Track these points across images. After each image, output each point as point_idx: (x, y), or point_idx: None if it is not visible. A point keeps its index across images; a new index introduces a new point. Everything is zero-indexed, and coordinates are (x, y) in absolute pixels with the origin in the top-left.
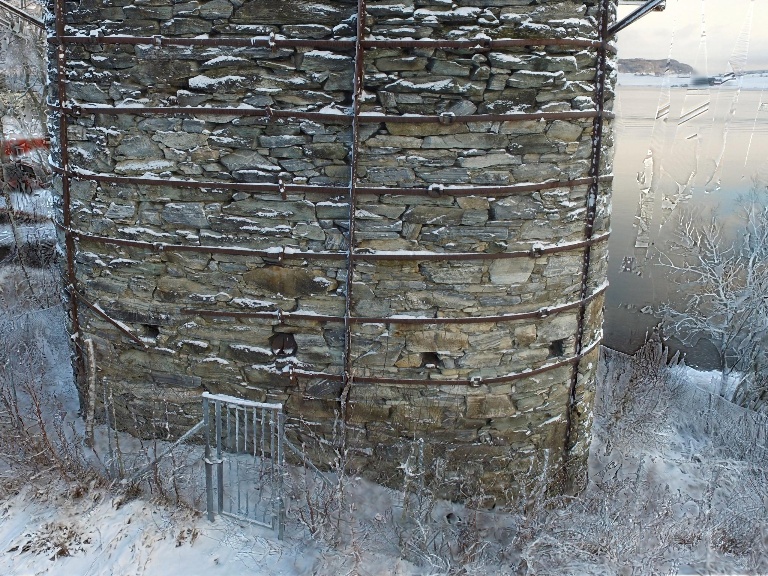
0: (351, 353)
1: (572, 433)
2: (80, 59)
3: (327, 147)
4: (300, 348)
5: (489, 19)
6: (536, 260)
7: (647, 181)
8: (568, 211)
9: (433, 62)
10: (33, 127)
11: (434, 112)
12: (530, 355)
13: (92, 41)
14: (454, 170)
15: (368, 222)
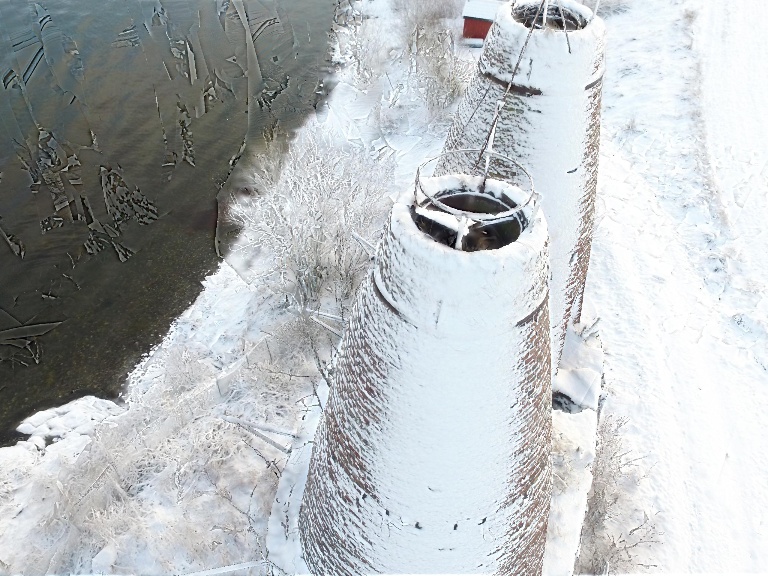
0: None
1: None
2: None
3: None
4: None
5: None
6: None
7: (64, 161)
8: None
9: None
10: None
11: None
12: None
13: None
14: None
15: None
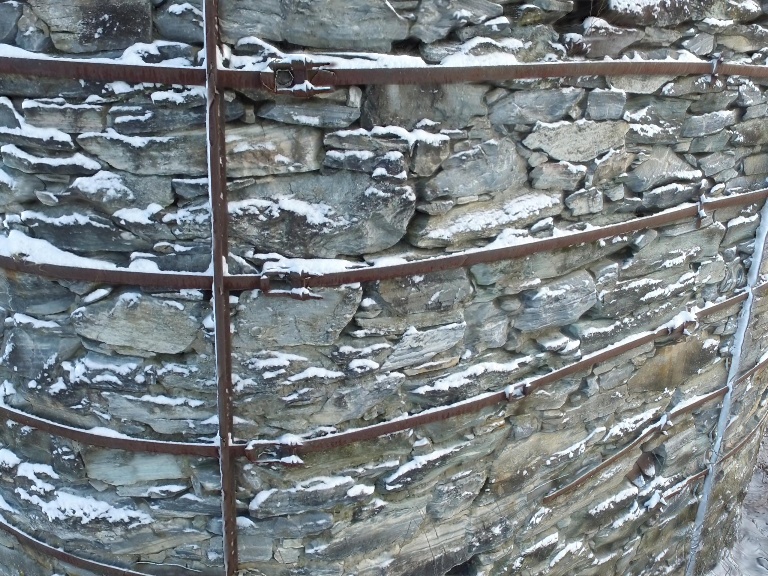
0: (716, 432)
1: None
2: None
3: (757, 126)
4: (670, 459)
5: None
6: None
7: None
8: None
9: None
10: None
11: None
12: None
13: None
14: None
15: None
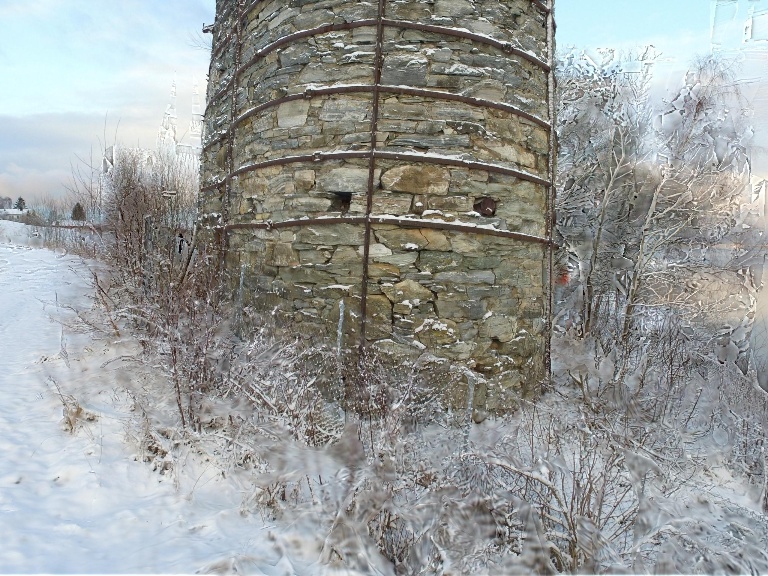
0: None
1: (377, 321)
2: None
3: None
4: None
5: None
6: (311, 103)
7: None
8: None
9: None
10: None
11: None
12: (309, 203)
13: None
14: None
15: None
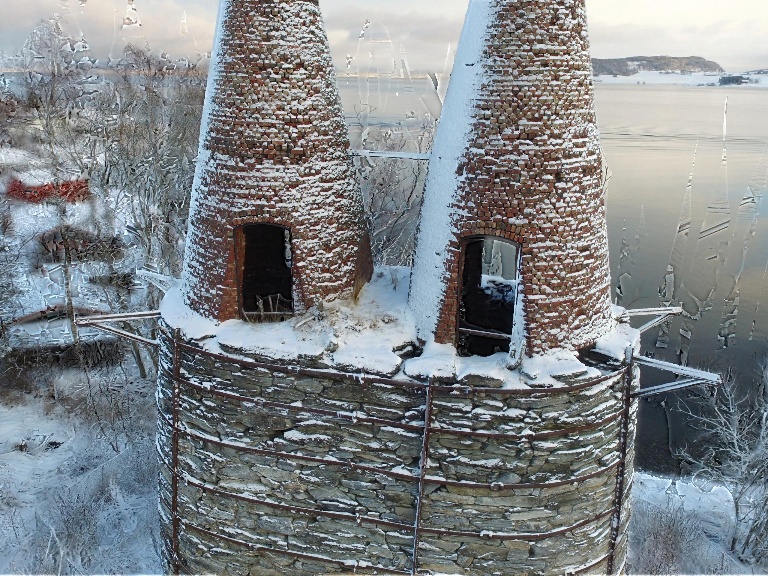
0: None
1: None
2: (192, 397)
3: (397, 495)
4: None
5: (533, 418)
6: None
7: (668, 295)
8: (595, 537)
9: (486, 445)
10: (101, 269)
11: (486, 481)
12: None
13: (204, 390)
14: (501, 521)
15: (429, 552)
